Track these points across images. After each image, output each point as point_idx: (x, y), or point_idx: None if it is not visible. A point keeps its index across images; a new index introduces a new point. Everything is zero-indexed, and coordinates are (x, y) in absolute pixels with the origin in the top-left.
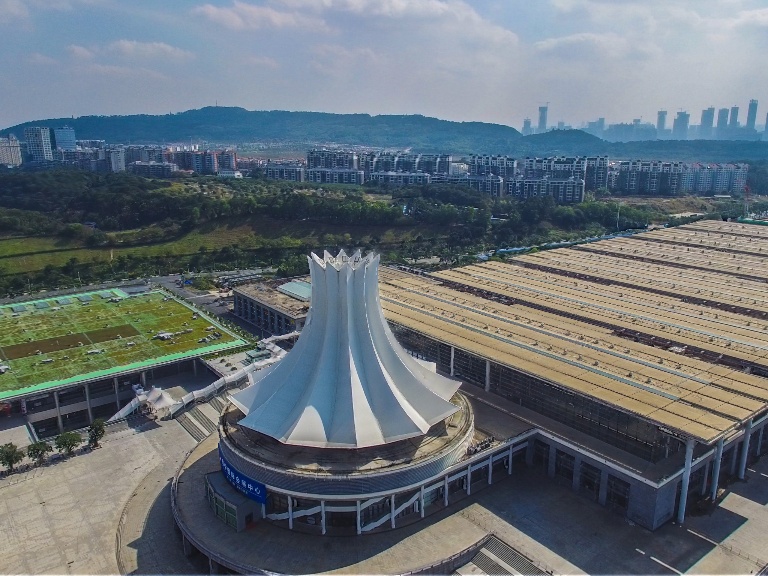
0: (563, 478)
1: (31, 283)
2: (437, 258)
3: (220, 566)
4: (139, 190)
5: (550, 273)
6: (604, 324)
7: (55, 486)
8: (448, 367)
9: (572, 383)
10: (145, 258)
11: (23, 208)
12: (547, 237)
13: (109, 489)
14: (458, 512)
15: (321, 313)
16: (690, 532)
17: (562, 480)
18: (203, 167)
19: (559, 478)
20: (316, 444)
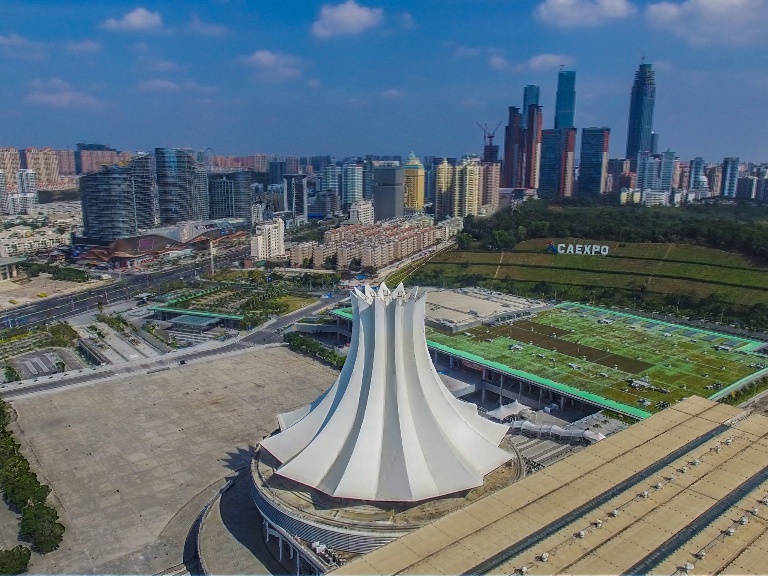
0: None
1: None
2: None
3: None
4: None
5: None
6: None
7: None
8: None
9: (360, 570)
10: None
11: None
12: None
13: None
14: None
15: None
16: None
17: None
18: None
19: None
20: None
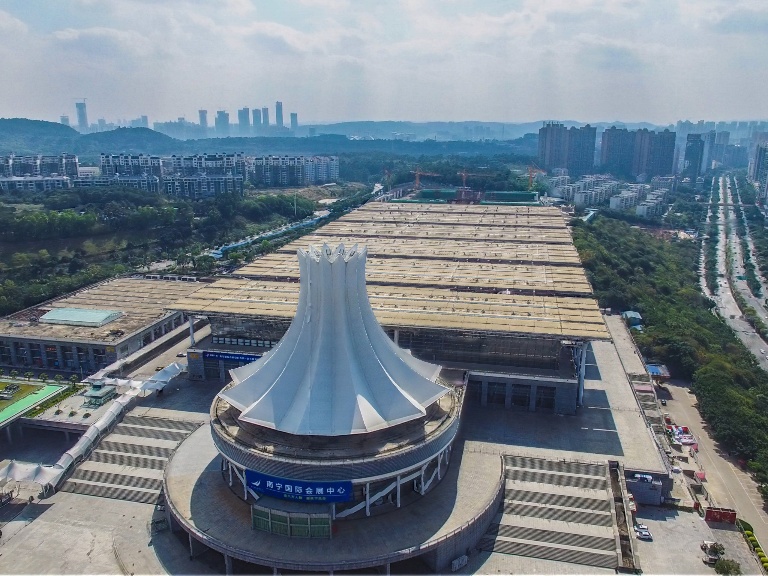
0: (493, 404)
1: None
2: (158, 264)
3: (344, 573)
4: None
5: None
6: (438, 286)
7: None
8: None
9: (493, 327)
10: None
11: None
12: (248, 230)
13: None
14: (464, 451)
15: (329, 307)
16: (591, 408)
17: (495, 405)
18: None
19: (491, 405)
20: (382, 426)
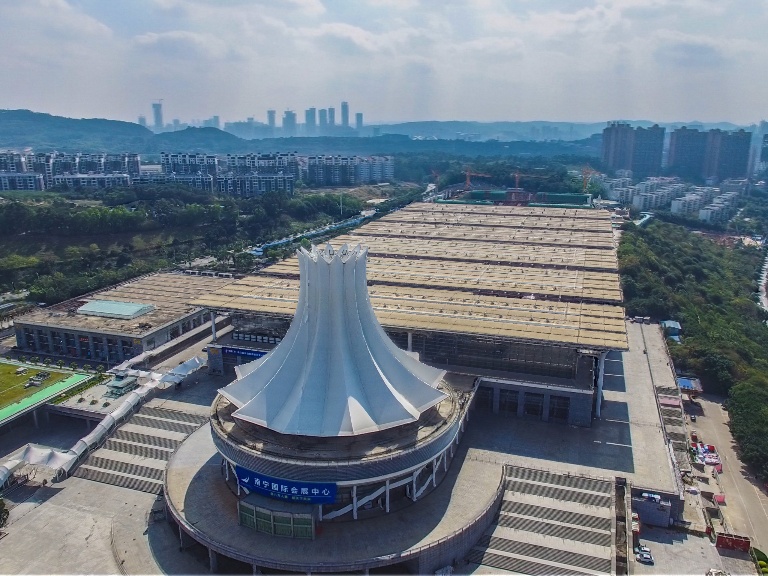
0: (505, 412)
1: None
2: (201, 260)
3: (321, 575)
4: None
5: None
6: (461, 289)
7: None
8: None
9: (506, 333)
10: None
11: None
12: (292, 229)
13: (79, 569)
14: (466, 459)
15: (326, 307)
16: (609, 421)
17: (507, 413)
18: None
19: (503, 412)
20: (372, 429)
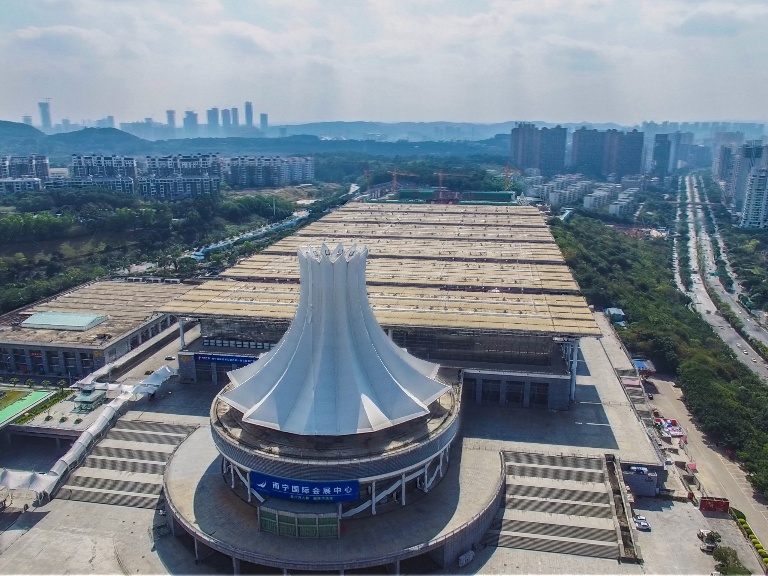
0: (487, 401)
1: None
2: (138, 266)
3: (354, 572)
4: None
5: None
6: (427, 285)
7: None
8: None
9: (487, 325)
10: None
11: None
12: (227, 232)
13: None
14: (463, 448)
15: (330, 307)
16: (583, 403)
17: (489, 402)
18: None
19: (486, 402)
20: (387, 425)
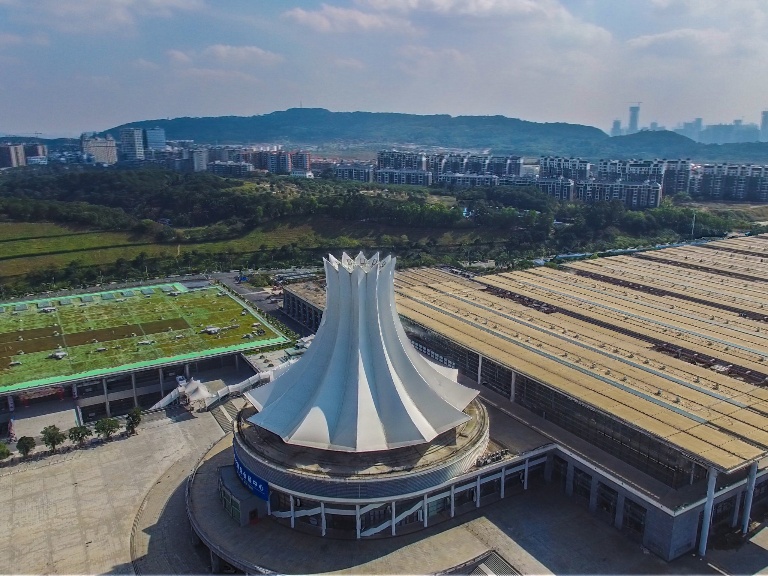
0: (581, 497)
1: (102, 275)
2: (494, 262)
3: (220, 558)
4: (212, 189)
5: (601, 281)
6: (645, 337)
7: (89, 468)
8: (476, 374)
9: (592, 398)
10: (209, 254)
11: (108, 204)
12: (613, 243)
13: (137, 475)
14: (463, 524)
15: (334, 315)
16: (710, 566)
17: (579, 499)
18: (278, 167)
19: (576, 497)
20: (318, 445)
